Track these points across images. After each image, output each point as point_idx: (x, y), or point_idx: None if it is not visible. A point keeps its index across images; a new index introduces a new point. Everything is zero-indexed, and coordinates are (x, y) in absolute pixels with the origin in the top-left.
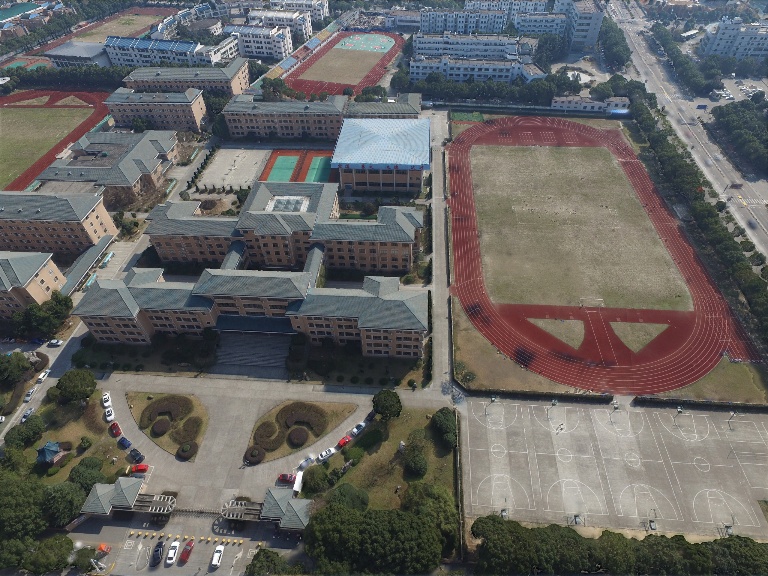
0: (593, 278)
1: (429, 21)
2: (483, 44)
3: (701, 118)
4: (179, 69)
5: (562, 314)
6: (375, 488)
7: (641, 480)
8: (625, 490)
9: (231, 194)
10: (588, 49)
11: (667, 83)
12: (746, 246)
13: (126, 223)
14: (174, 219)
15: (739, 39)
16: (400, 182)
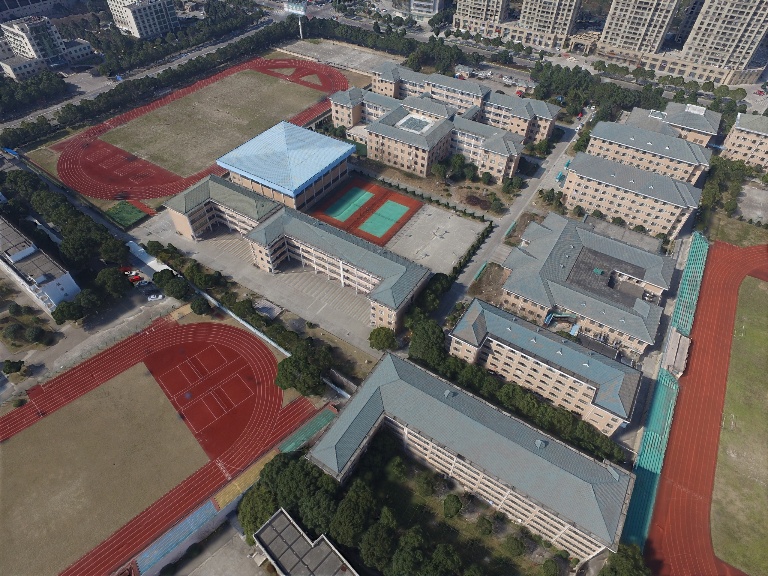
0: None
1: None
2: None
3: None
4: (490, 425)
5: (304, 82)
6: (431, 71)
7: (344, 53)
8: (352, 53)
9: (449, 206)
10: None
11: None
12: None
13: (550, 192)
14: (501, 129)
15: None
16: None
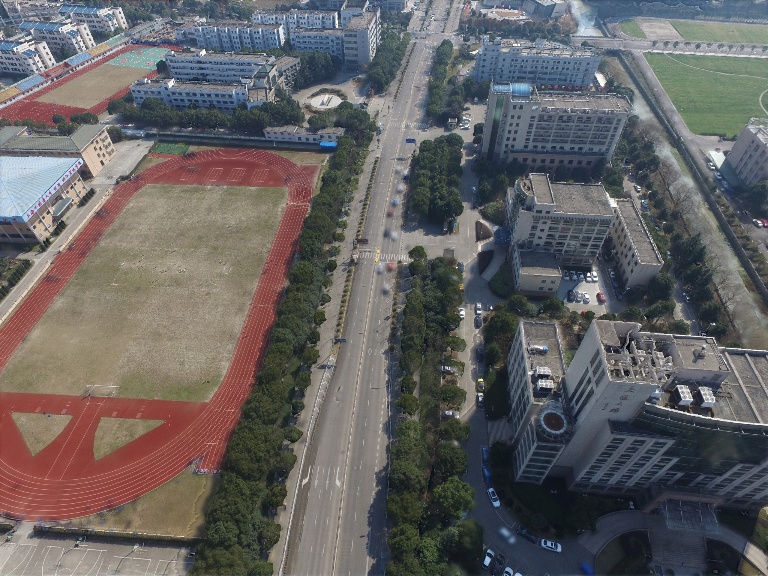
0: (132, 358)
1: (204, 36)
2: (237, 64)
3: (415, 152)
4: None
5: (56, 407)
6: None
7: None
8: None
9: None
10: (363, 68)
11: (416, 109)
12: (315, 319)
13: None
14: None
15: (501, 61)
16: (12, 233)
